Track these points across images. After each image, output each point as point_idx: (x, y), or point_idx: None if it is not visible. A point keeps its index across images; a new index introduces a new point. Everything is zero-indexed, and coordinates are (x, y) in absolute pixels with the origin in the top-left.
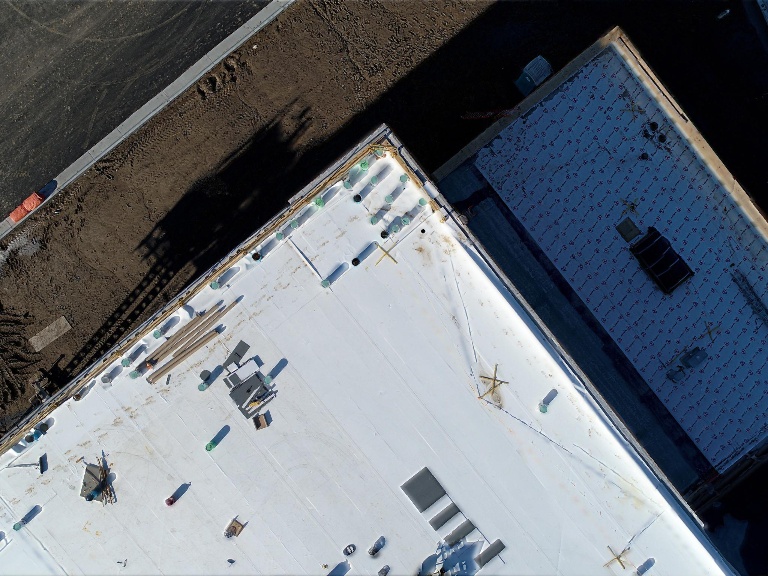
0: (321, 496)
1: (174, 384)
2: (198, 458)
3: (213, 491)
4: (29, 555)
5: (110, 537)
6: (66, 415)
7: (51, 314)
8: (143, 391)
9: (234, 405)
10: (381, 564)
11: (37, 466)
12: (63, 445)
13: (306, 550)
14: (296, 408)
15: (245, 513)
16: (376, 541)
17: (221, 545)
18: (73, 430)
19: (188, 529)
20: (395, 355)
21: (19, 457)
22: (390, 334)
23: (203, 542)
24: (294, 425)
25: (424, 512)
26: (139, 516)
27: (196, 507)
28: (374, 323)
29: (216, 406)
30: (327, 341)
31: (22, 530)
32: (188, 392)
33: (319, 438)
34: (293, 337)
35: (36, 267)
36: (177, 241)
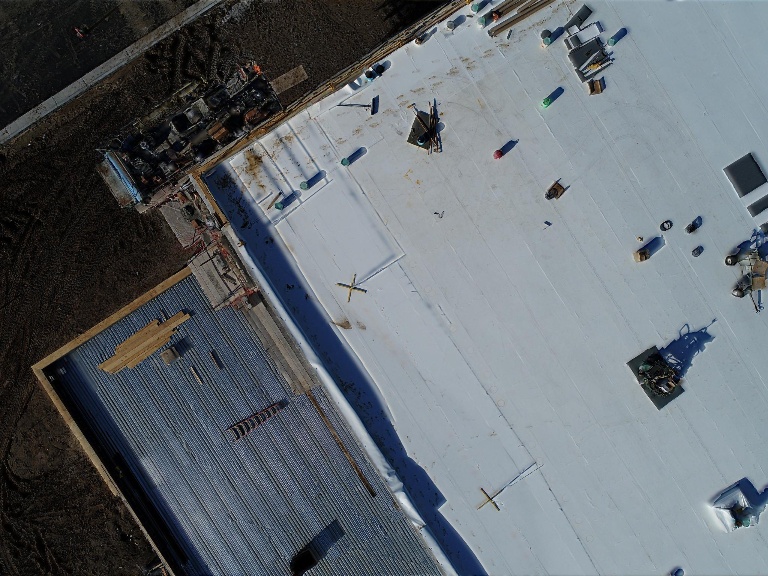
0: (644, 169)
1: (514, 40)
2: (529, 116)
3: (539, 151)
4: (347, 197)
5: (431, 187)
6: (403, 59)
7: (289, 62)
8: (483, 43)
9: (570, 68)
10: (696, 244)
11: (368, 107)
12: (396, 89)
13: (623, 221)
14: (630, 78)
15: (568, 177)
16: (693, 221)
17: (540, 207)
18: (408, 75)
19: (509, 187)
20: (732, 39)
21: (351, 97)
22: (730, 17)
23: (523, 201)
24: (626, 95)
25: (743, 197)
26: (462, 169)
27: (520, 165)
28: (716, 4)
29: (553, 67)
30: (668, 16)
31: (343, 171)
32: (527, 50)
33: (649, 111)
34: (635, 8)
35: (279, 15)
36: (422, 4)
